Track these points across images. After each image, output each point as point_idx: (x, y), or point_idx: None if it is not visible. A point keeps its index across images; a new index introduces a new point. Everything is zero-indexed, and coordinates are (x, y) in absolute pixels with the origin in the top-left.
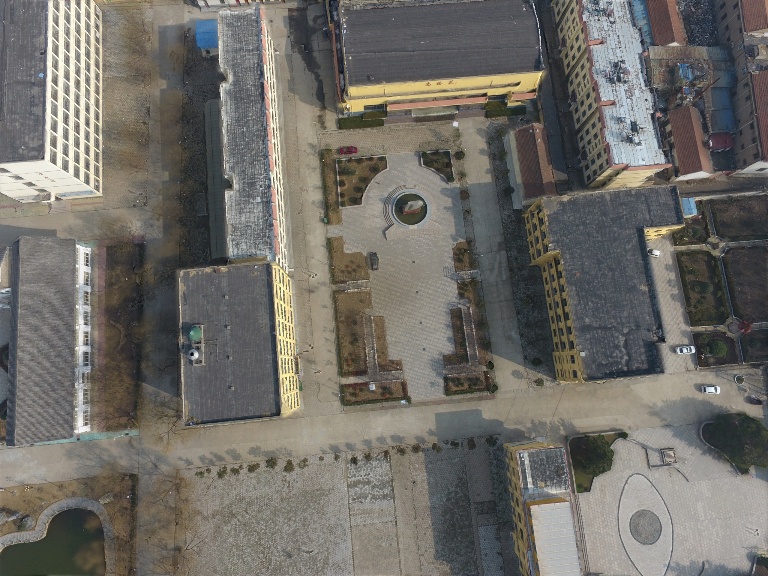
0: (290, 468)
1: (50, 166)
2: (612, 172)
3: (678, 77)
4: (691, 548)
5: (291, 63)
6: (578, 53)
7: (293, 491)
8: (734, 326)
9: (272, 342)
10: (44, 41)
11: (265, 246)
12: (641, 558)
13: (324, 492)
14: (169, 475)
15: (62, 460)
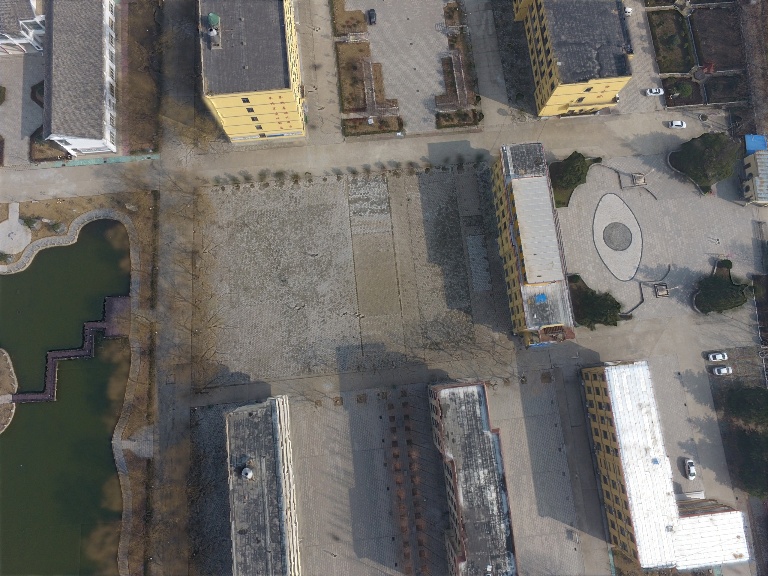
0: (297, 187)
1: None
2: None
3: None
4: (658, 254)
5: None
6: None
7: (299, 206)
8: (699, 71)
9: (281, 33)
10: None
11: None
12: (613, 261)
13: (327, 207)
14: (187, 192)
15: (91, 178)
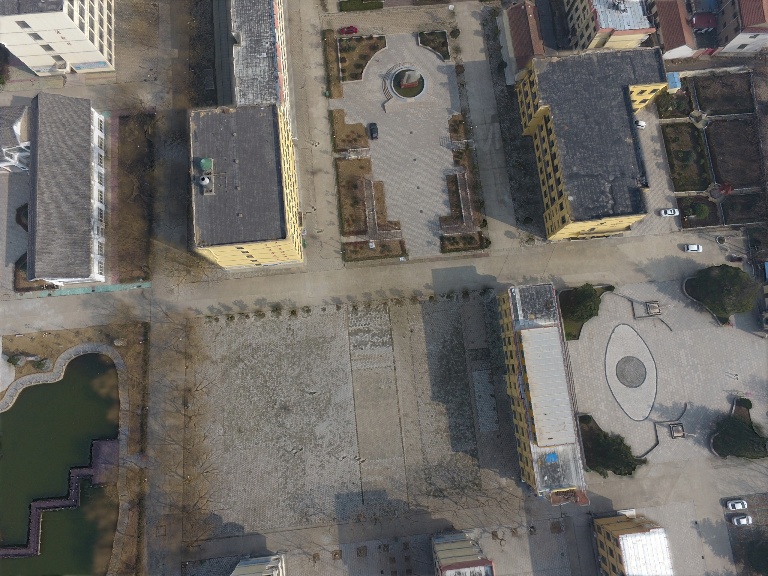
0: (294, 318)
1: (68, 21)
2: (599, 41)
3: None
4: (674, 391)
5: None
6: None
7: (297, 338)
8: (716, 190)
9: (278, 175)
10: None
11: (271, 97)
12: (627, 399)
13: (326, 339)
14: (179, 323)
15: (78, 309)
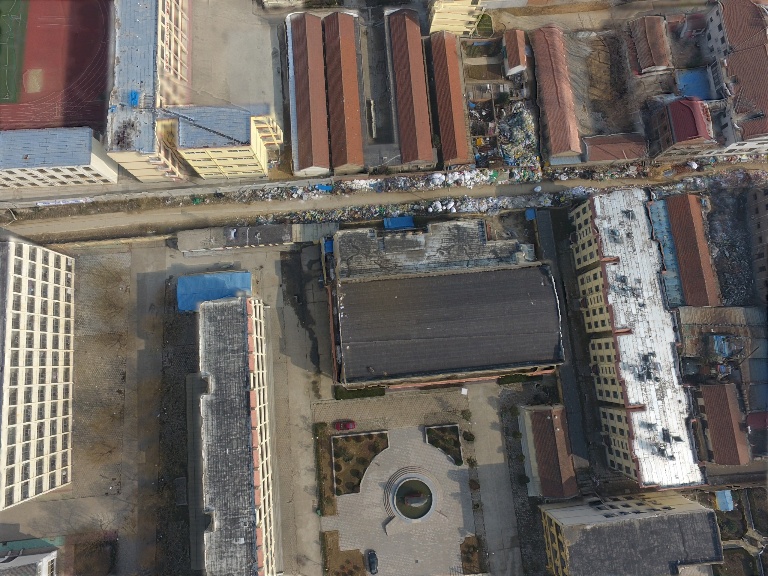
0: None
1: None
2: None
3: (713, 350)
4: None
5: (283, 318)
6: (602, 326)
7: None
8: None
9: None
10: (1, 356)
11: None
12: None
13: None
14: None
15: None
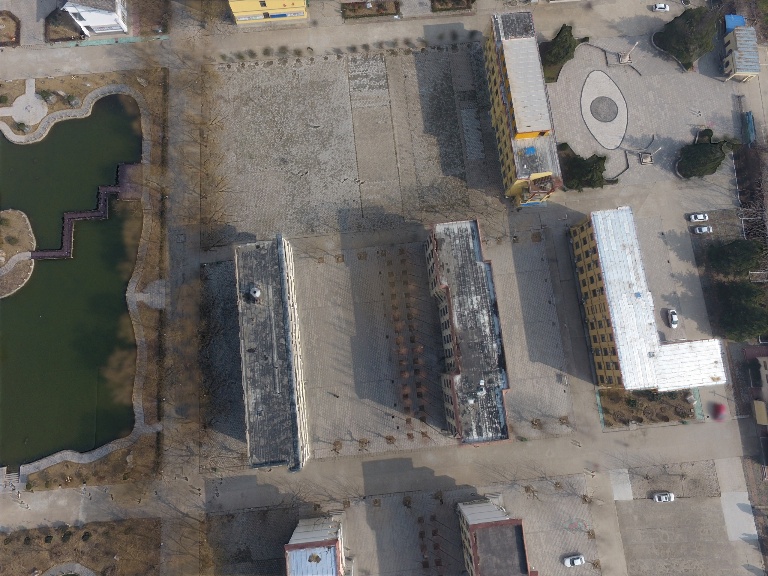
0: (299, 65)
1: None
2: None
3: None
4: (643, 125)
5: None
6: None
7: (302, 82)
8: None
9: None
10: None
11: None
12: (600, 132)
13: (328, 83)
14: (195, 69)
15: (103, 57)
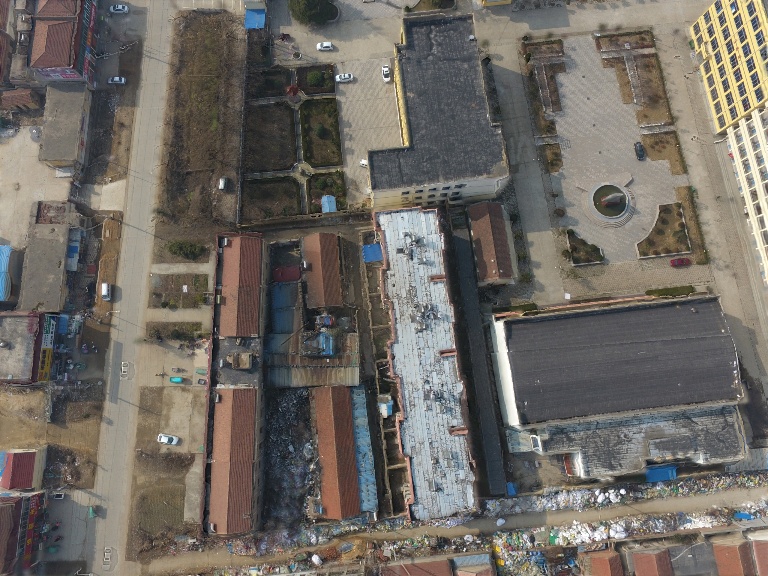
0: None
1: None
2: None
3: None
4: None
5: (759, 365)
6: None
7: None
8: None
9: None
10: None
11: None
12: None
13: None
14: None
15: None
